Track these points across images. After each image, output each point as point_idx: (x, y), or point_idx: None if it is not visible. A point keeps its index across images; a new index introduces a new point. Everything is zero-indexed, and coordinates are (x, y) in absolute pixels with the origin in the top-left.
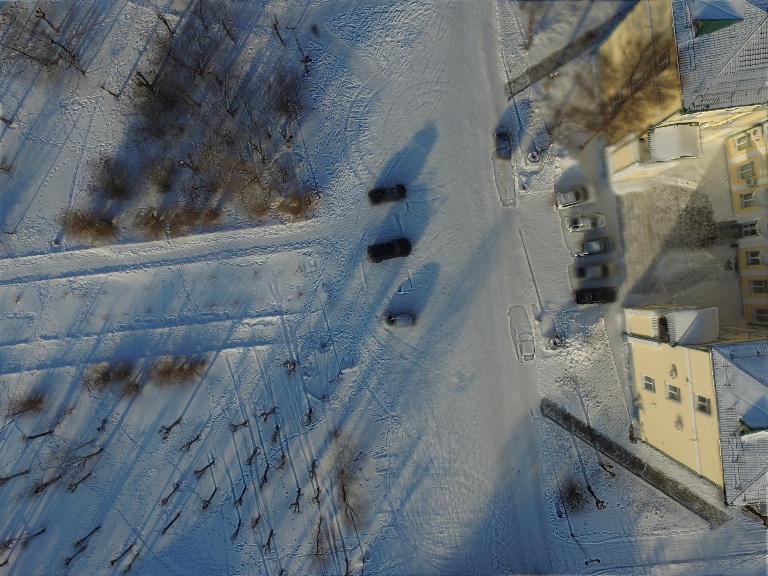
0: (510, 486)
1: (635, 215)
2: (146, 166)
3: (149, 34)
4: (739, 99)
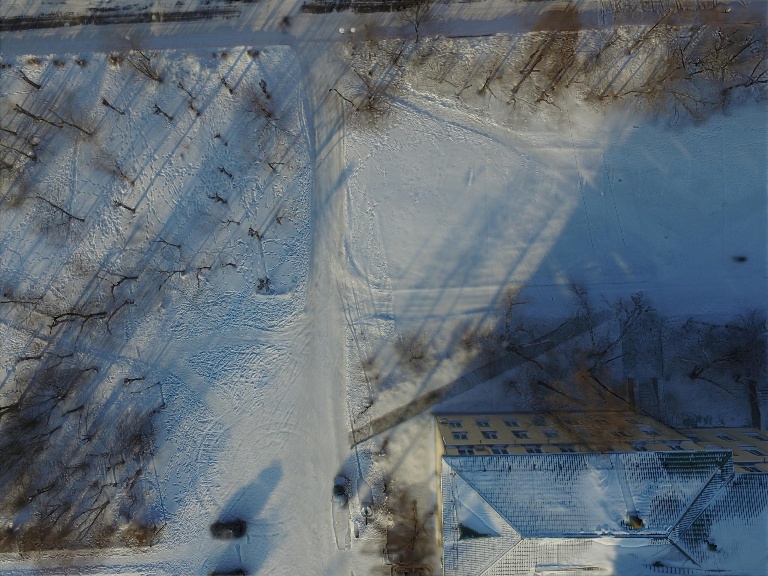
0: None
1: None
2: (4, 482)
3: (18, 355)
4: None
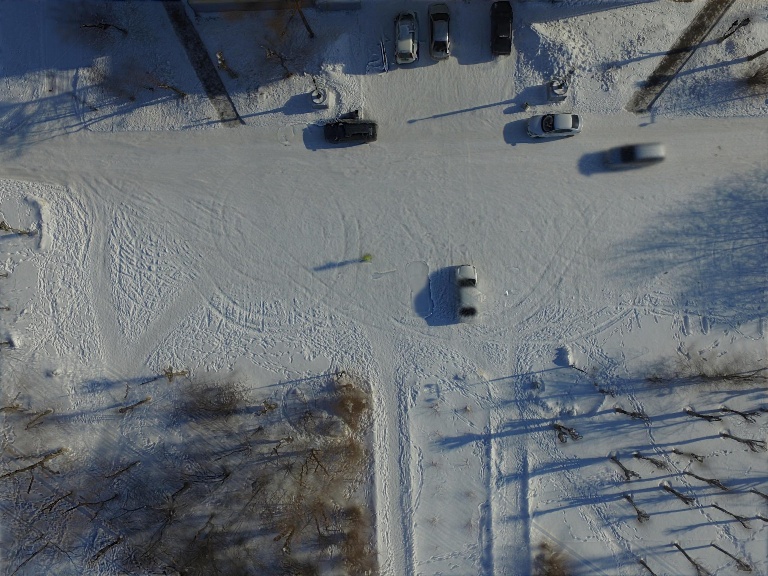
0: (738, 160)
1: None
2: None
3: (117, 570)
4: None
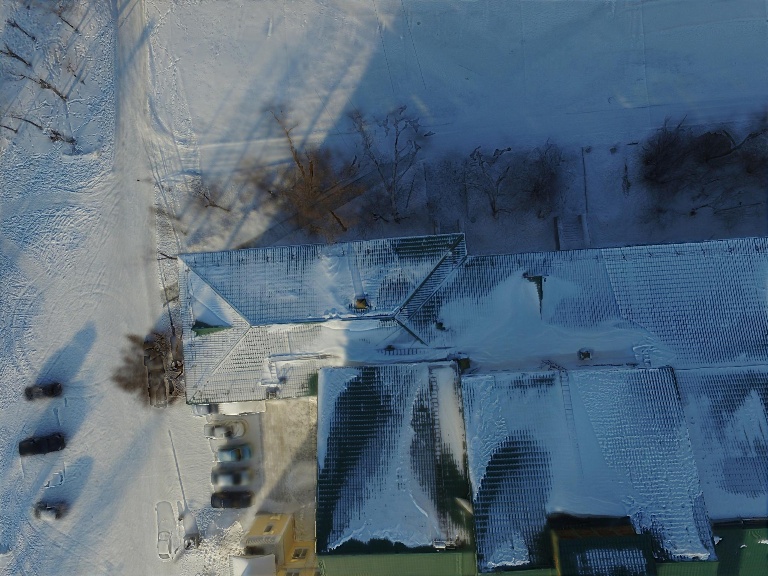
0: None
1: (272, 425)
2: None
3: None
4: (236, 395)
